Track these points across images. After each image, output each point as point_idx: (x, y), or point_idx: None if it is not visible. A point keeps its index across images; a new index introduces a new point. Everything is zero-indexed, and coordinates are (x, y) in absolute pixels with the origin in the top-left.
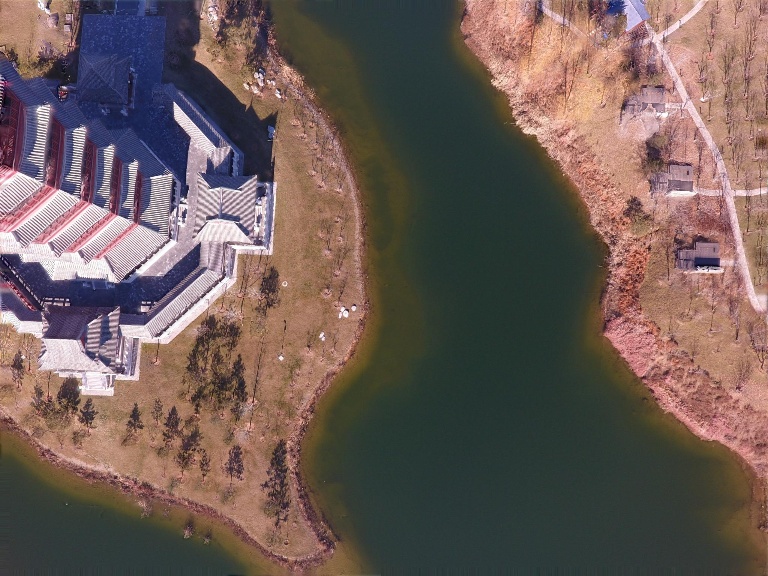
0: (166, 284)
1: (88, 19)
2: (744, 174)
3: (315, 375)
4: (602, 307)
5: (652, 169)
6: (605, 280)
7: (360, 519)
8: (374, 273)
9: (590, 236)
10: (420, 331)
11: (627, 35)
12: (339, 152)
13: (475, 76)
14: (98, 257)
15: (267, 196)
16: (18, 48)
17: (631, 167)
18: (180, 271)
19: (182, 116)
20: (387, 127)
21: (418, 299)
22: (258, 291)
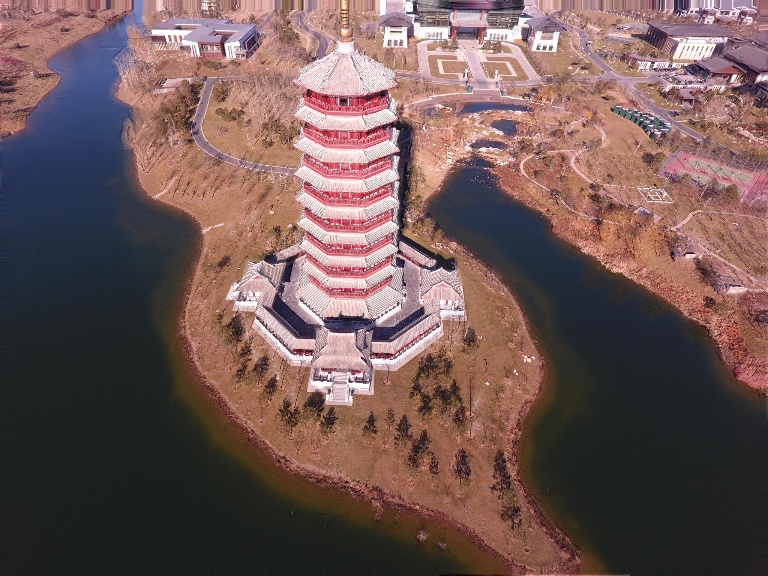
0: (395, 332)
1: None
2: None
3: (516, 400)
4: (724, 362)
5: (709, 279)
6: (715, 346)
7: (594, 530)
8: (540, 340)
9: (688, 323)
10: (589, 377)
11: None
12: (496, 278)
13: (569, 251)
14: (365, 296)
15: None
16: None
17: (694, 281)
18: (404, 325)
19: (405, 247)
20: (522, 271)
21: (579, 358)
22: (461, 341)
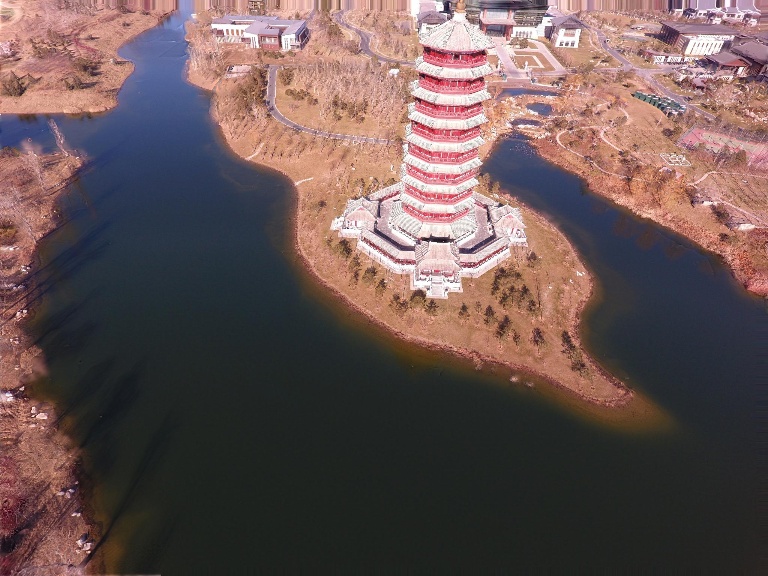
0: None
1: None
2: None
3: (573, 300)
4: (736, 279)
5: (723, 220)
6: (729, 269)
7: (641, 379)
8: (587, 263)
9: (706, 254)
10: (629, 288)
11: (677, 182)
12: (546, 220)
13: (604, 203)
14: (451, 221)
15: None
16: (379, 178)
17: (711, 222)
18: (479, 247)
19: None
20: (566, 216)
21: (619, 275)
22: (526, 259)
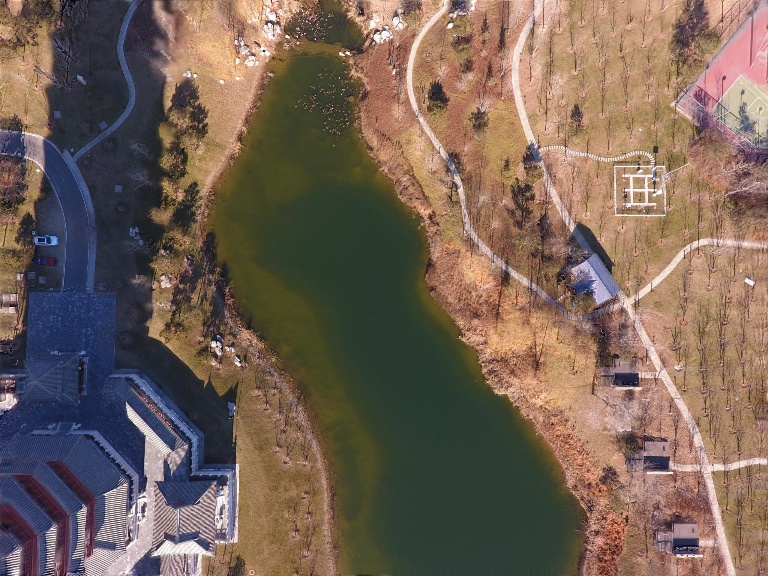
0: None
1: (34, 298)
2: (722, 447)
3: None
4: (580, 574)
5: None
6: (583, 544)
7: None
8: (345, 545)
9: (566, 496)
10: None
11: None
12: (304, 418)
13: (443, 326)
14: None
15: (229, 487)
16: None
17: (605, 438)
18: (142, 569)
19: (135, 416)
20: (353, 385)
21: (391, 569)
22: None
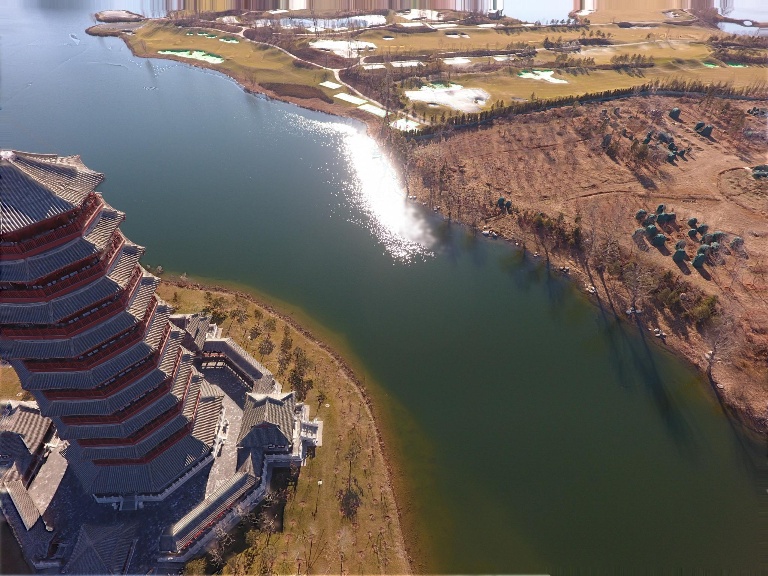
0: None
1: None
2: None
3: None
4: None
5: None
6: None
7: None
8: None
9: None
10: None
11: None
12: None
13: None
14: None
15: None
16: None
17: None
18: None
19: (28, 517)
20: None
21: None
22: None
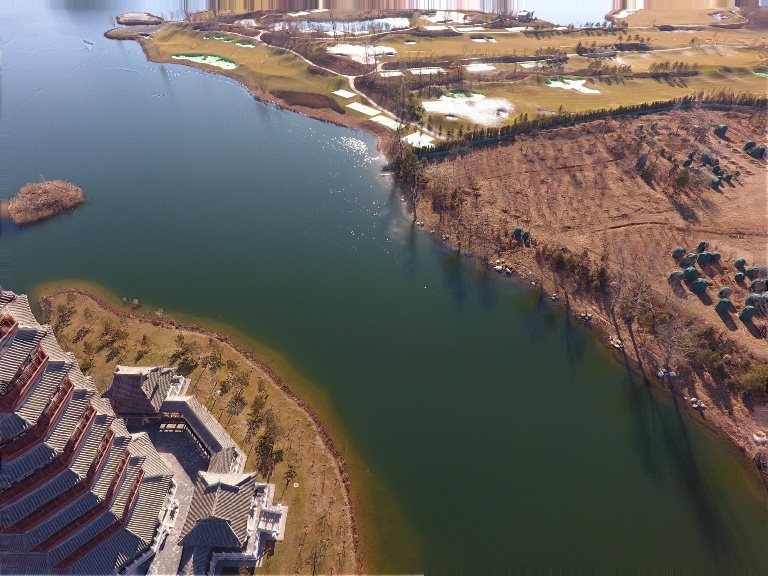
0: None
1: None
2: None
3: None
4: None
5: None
6: None
7: None
8: None
9: None
10: None
11: None
12: None
13: None
14: None
15: None
16: None
17: None
18: None
19: None
20: None
21: None
22: None
